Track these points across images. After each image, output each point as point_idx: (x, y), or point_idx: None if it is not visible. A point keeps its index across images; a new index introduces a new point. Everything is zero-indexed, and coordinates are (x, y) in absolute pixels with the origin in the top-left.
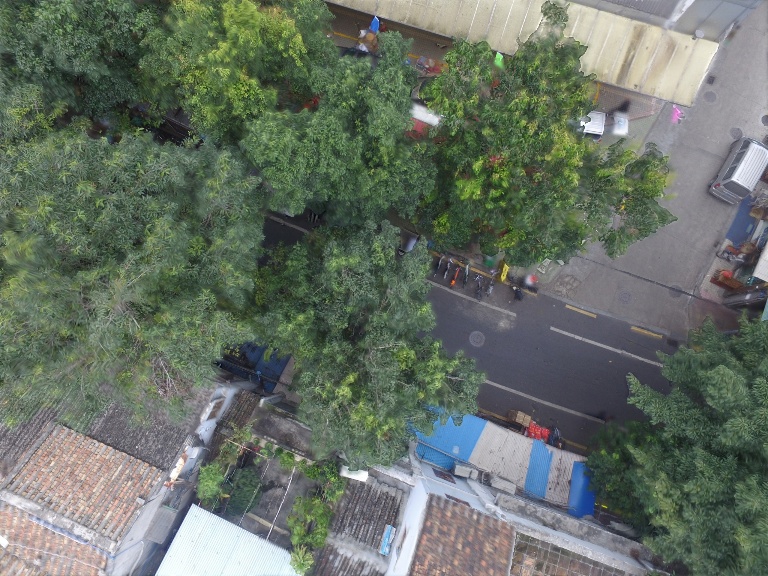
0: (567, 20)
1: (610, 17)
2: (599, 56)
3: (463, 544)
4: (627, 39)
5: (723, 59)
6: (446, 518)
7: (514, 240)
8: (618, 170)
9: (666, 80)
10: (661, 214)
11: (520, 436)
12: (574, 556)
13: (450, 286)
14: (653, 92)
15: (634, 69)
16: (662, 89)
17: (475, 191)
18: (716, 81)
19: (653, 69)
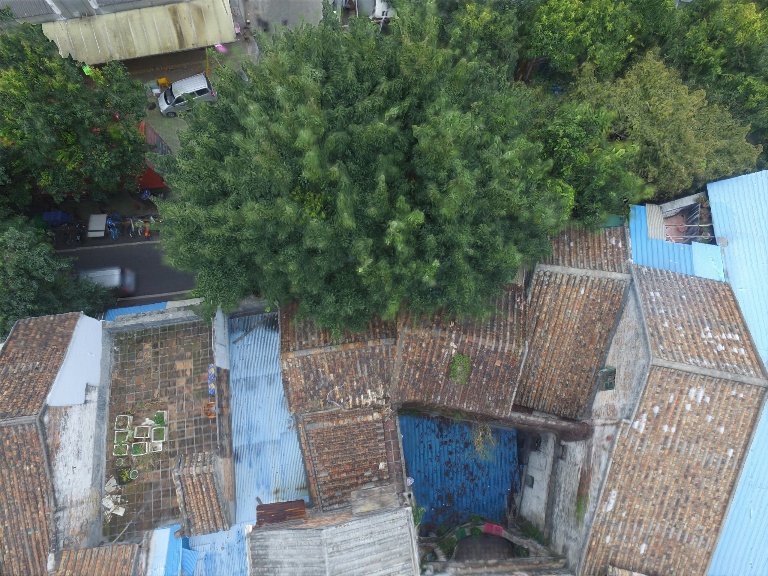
0: (11, 14)
1: (149, 10)
2: (158, 37)
3: (41, 335)
4: (168, 18)
5: (288, 7)
6: (28, 327)
7: (77, 161)
8: (56, 78)
9: (210, 32)
10: (132, 97)
11: (193, 299)
12: (178, 328)
13: (147, 238)
14: (206, 43)
15: (186, 35)
16: (211, 39)
17: (2, 136)
18: (288, 22)
19: (198, 29)
